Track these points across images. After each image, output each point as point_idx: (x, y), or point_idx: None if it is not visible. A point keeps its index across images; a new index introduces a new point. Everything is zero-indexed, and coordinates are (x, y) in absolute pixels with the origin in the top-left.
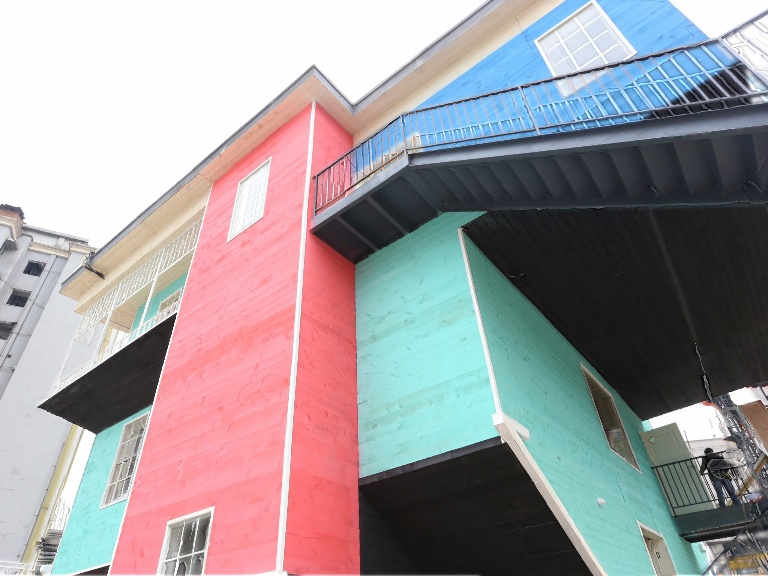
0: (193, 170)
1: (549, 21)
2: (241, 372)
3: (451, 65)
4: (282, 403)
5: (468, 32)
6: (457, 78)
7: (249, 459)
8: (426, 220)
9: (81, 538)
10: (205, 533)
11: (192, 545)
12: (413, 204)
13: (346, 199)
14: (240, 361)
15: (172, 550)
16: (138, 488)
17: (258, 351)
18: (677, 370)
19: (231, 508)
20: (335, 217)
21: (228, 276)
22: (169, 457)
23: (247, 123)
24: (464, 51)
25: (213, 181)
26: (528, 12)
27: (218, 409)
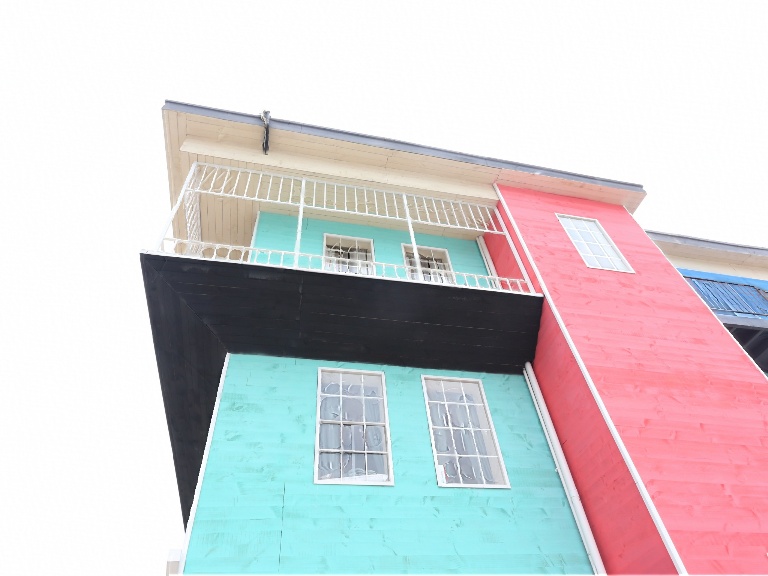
0: (489, 159)
1: (762, 285)
2: (746, 420)
3: (687, 258)
4: None
5: (713, 250)
6: (699, 271)
7: None
8: None
9: (275, 521)
10: None
11: None
12: None
13: (745, 320)
14: (732, 408)
15: None
16: (661, 495)
17: (754, 409)
18: None
19: None
20: (735, 326)
21: (625, 306)
22: (695, 473)
23: (567, 173)
24: (698, 257)
25: (497, 183)
26: (739, 267)
27: (741, 446)
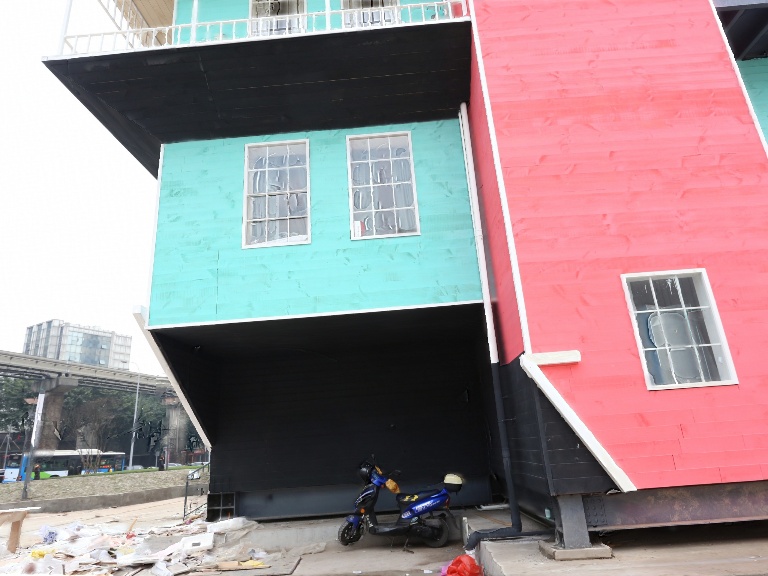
0: None
1: None
2: (675, 139)
3: None
4: (767, 187)
5: None
6: None
7: (740, 231)
8: (750, 54)
9: (212, 280)
10: (696, 291)
11: (679, 300)
12: (766, 33)
13: None
14: (665, 126)
15: (643, 303)
16: (526, 232)
17: (696, 123)
18: None
19: (734, 273)
20: (742, 8)
21: (577, 11)
22: (576, 207)
23: None
24: None
25: None
26: None
27: (651, 171)
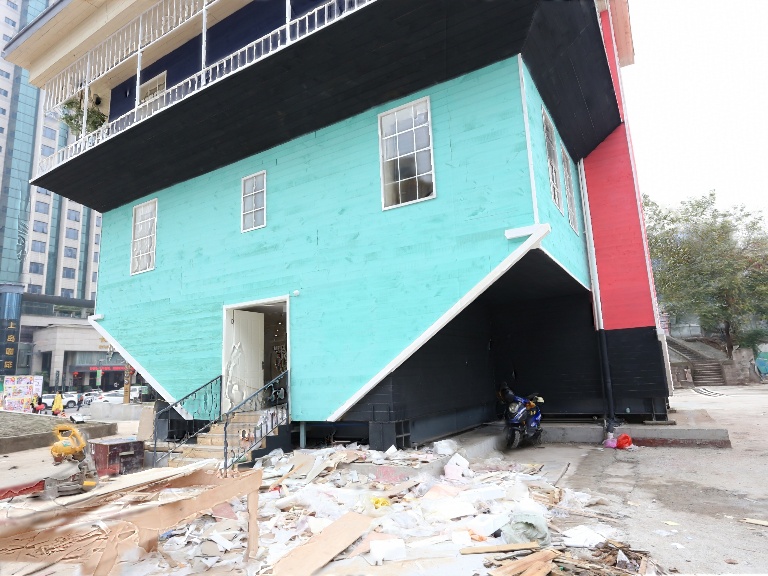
0: None
1: None
2: None
3: None
4: None
5: None
6: None
7: None
8: None
9: None
10: None
11: None
12: None
13: None
14: None
15: None
16: None
17: None
18: None
19: None
20: None
21: None
22: None
23: None
24: None
25: None
26: None
27: None
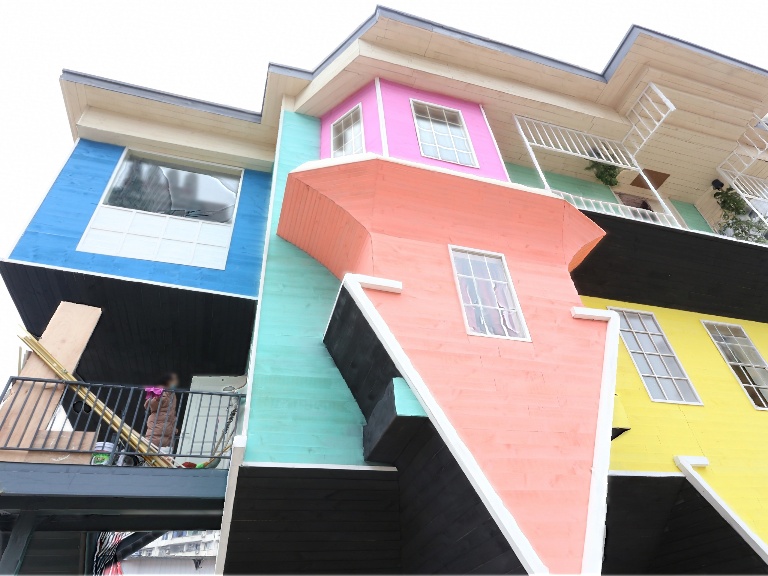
0: None
1: None
2: None
3: None
4: None
5: None
6: None
7: None
8: None
9: None
10: None
11: None
12: None
13: None
14: None
15: None
16: None
17: None
18: (170, 367)
19: None
20: None
21: None
22: None
23: None
24: None
25: None
26: None
27: None
